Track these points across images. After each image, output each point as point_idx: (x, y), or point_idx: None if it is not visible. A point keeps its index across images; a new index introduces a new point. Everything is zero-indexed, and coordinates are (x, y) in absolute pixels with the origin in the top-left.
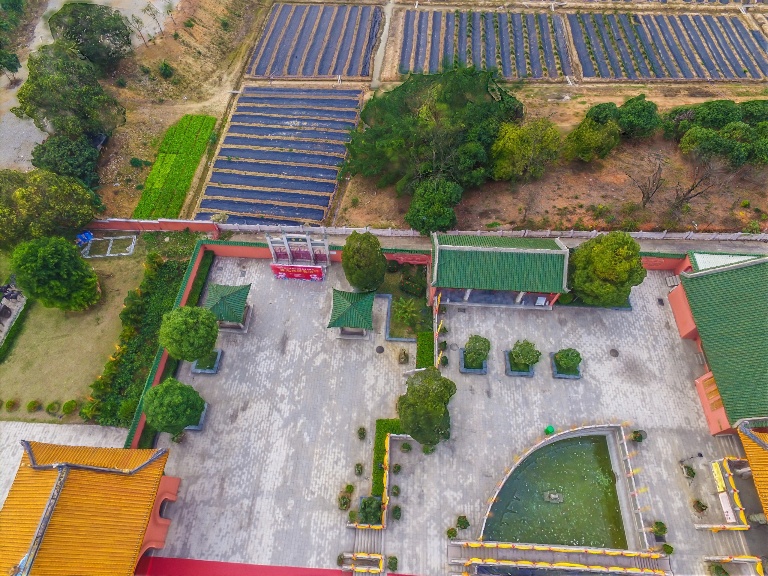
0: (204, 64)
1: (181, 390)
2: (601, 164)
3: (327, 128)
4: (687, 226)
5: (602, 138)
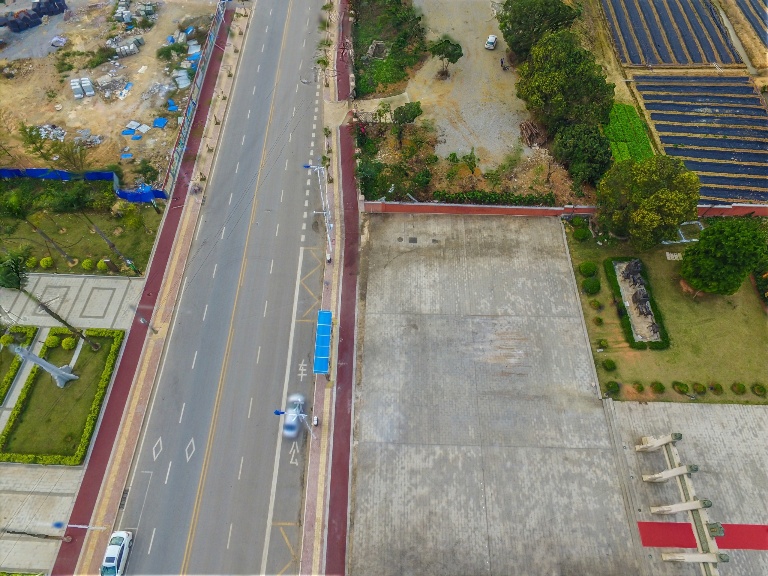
0: None
1: None
2: None
3: (744, 114)
4: None
5: None
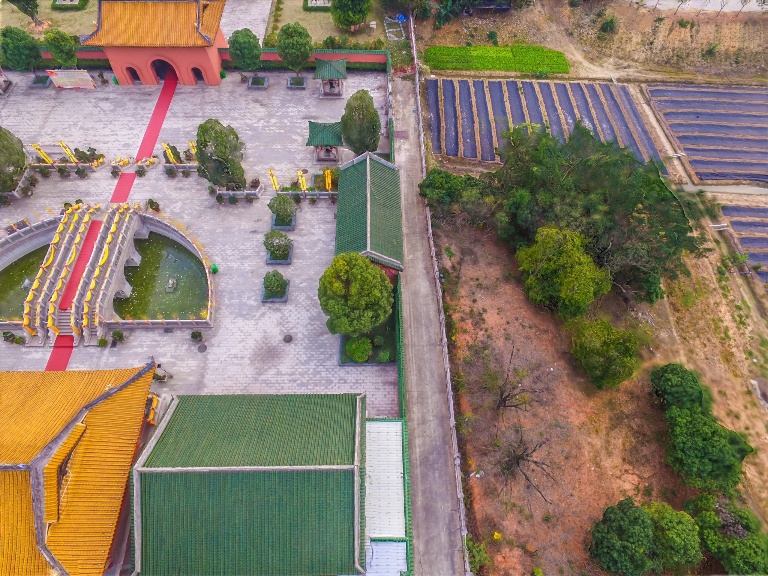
0: (640, 51)
1: (249, 43)
2: (593, 394)
3: None
4: (473, 460)
5: (591, 342)
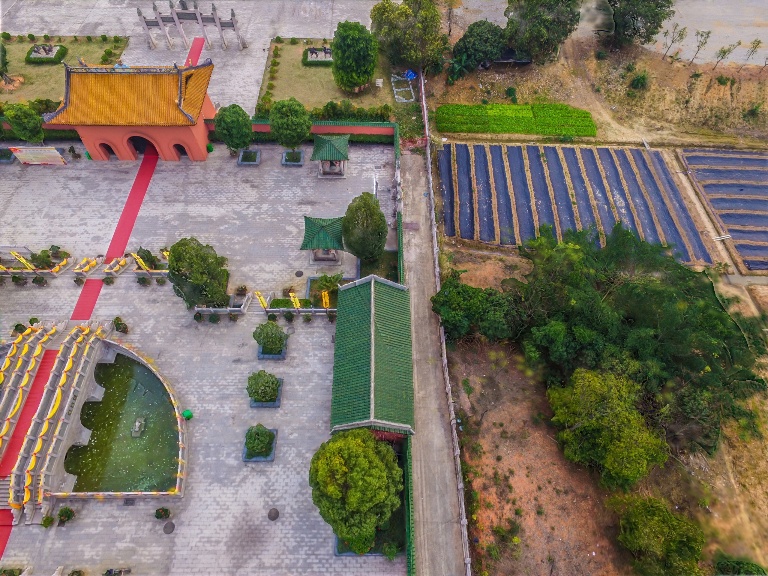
0: (674, 110)
1: (237, 122)
2: None
3: None
4: None
5: (649, 546)
